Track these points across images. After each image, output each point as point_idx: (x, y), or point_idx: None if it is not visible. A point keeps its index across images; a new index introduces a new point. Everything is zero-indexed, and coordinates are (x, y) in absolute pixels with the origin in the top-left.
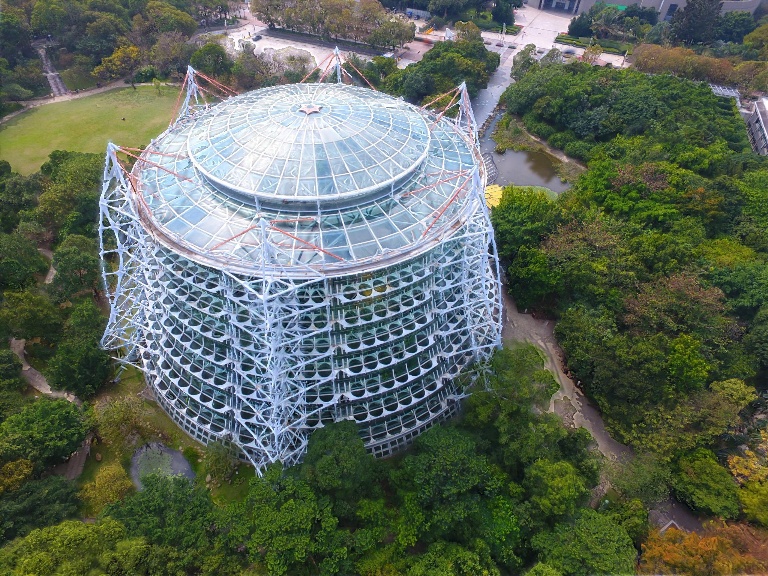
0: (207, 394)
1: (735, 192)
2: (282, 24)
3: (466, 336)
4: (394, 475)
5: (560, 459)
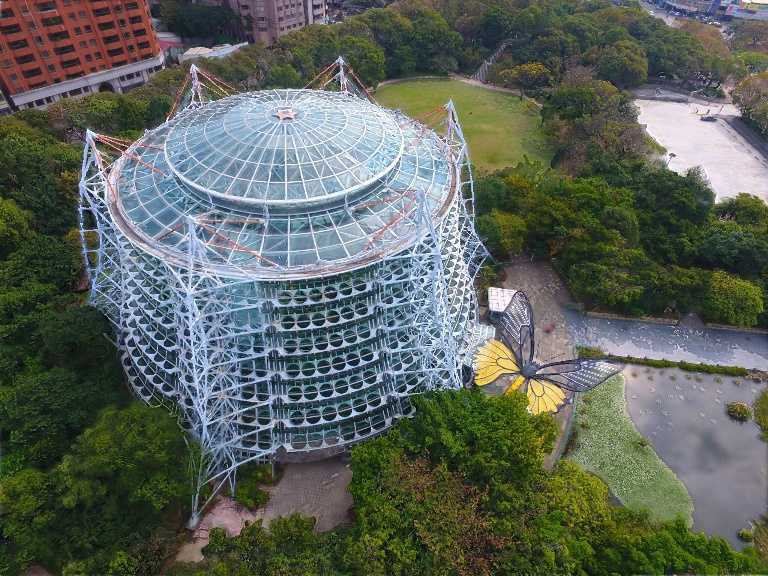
0: None
1: None
2: (752, 118)
3: None
4: None
5: (109, 550)
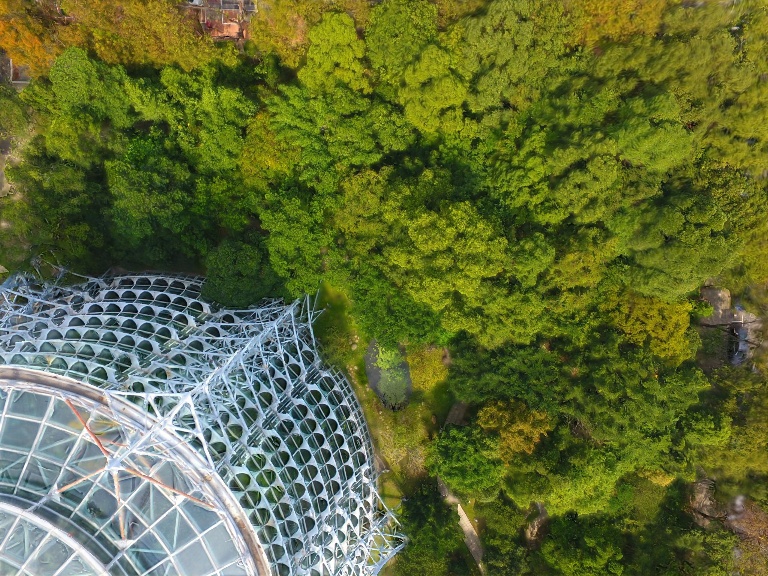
0: (322, 414)
1: None
2: None
3: None
4: (203, 247)
5: None
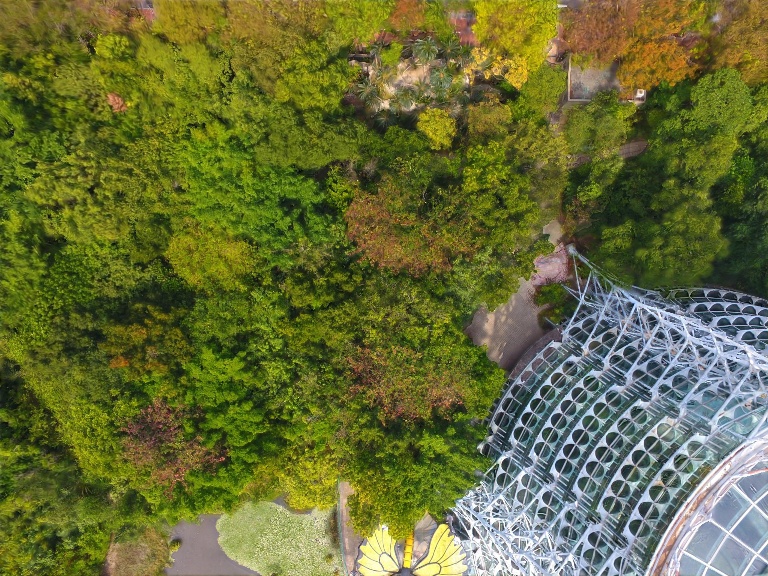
0: None
1: (67, 330)
2: None
3: (663, 331)
4: None
5: None
